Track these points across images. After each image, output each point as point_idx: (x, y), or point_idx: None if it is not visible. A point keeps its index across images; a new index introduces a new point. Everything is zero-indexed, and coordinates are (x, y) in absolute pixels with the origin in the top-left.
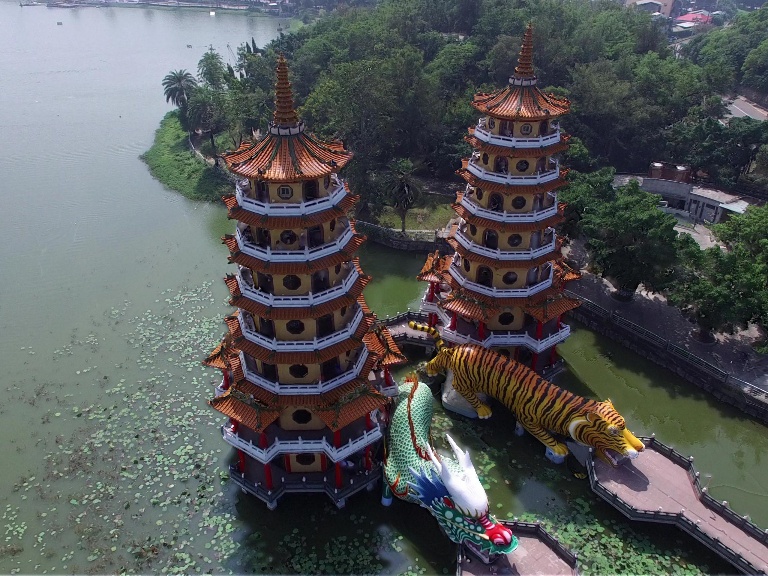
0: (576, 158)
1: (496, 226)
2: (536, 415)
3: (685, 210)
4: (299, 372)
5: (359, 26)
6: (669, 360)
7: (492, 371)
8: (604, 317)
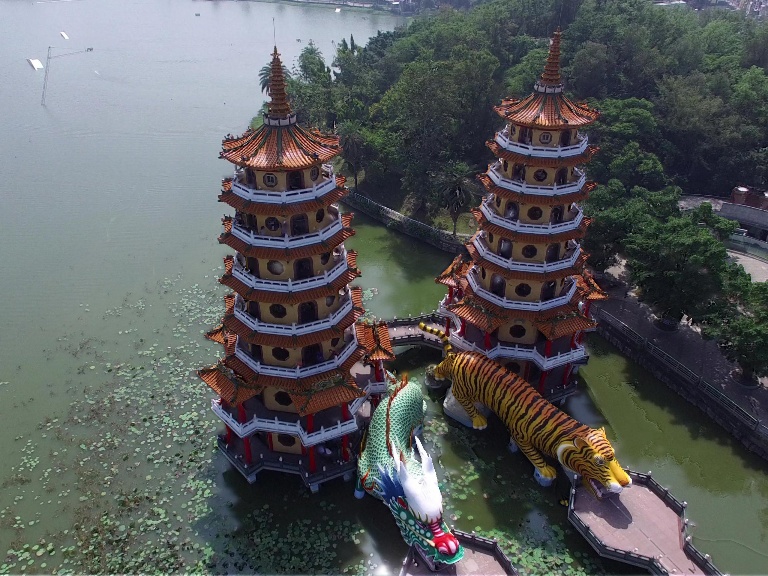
0: (652, 175)
1: (508, 235)
2: (527, 433)
3: (765, 241)
4: (281, 355)
5: (448, 27)
6: (699, 398)
7: (489, 382)
8: (638, 344)
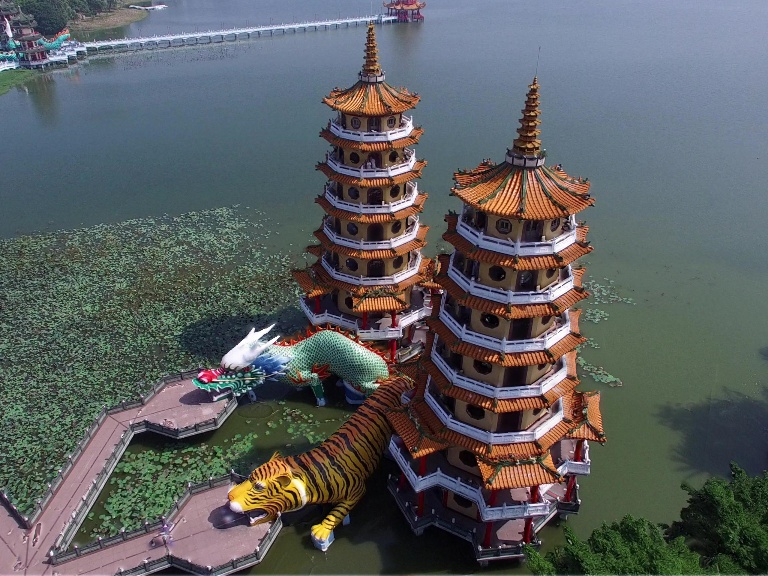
0: None
1: None
2: None
3: None
4: None
5: None
6: None
7: None
8: None
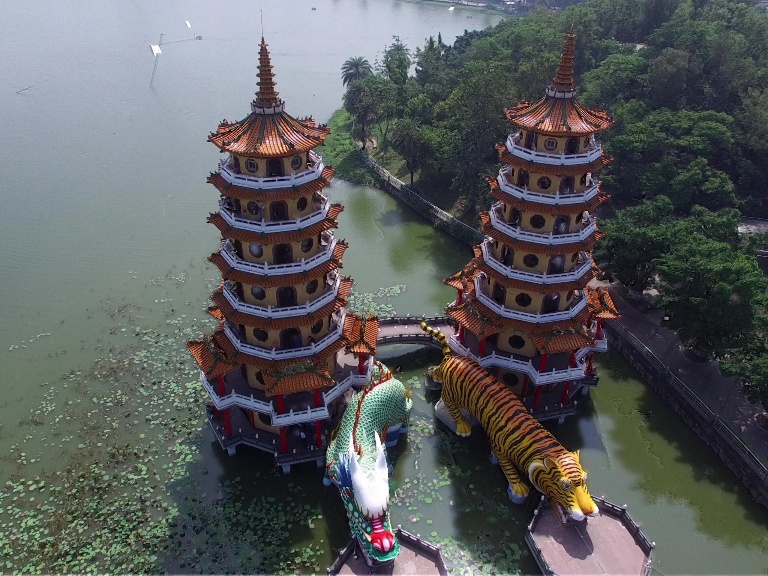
0: (723, 195)
1: (506, 241)
2: (504, 446)
3: None
4: (261, 336)
5: (529, 28)
6: (713, 437)
7: (473, 389)
8: (659, 372)
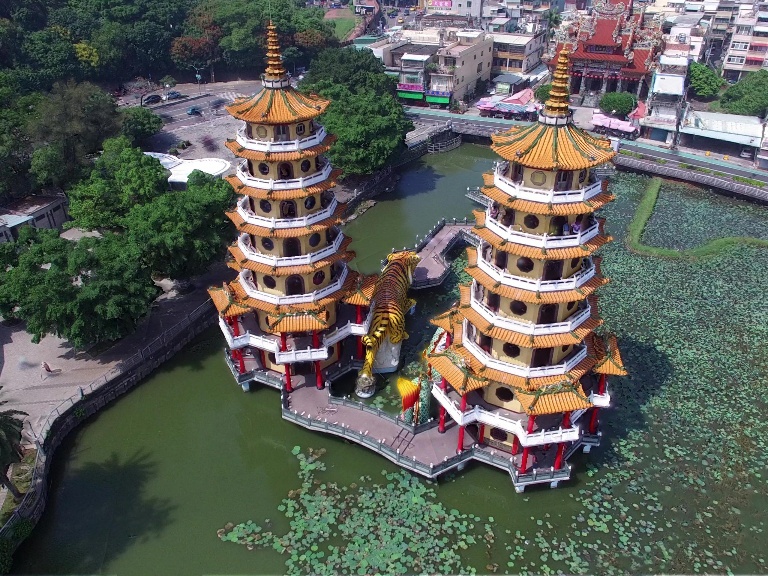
0: None
1: (344, 207)
2: None
3: None
4: None
5: None
6: None
7: None
8: None
